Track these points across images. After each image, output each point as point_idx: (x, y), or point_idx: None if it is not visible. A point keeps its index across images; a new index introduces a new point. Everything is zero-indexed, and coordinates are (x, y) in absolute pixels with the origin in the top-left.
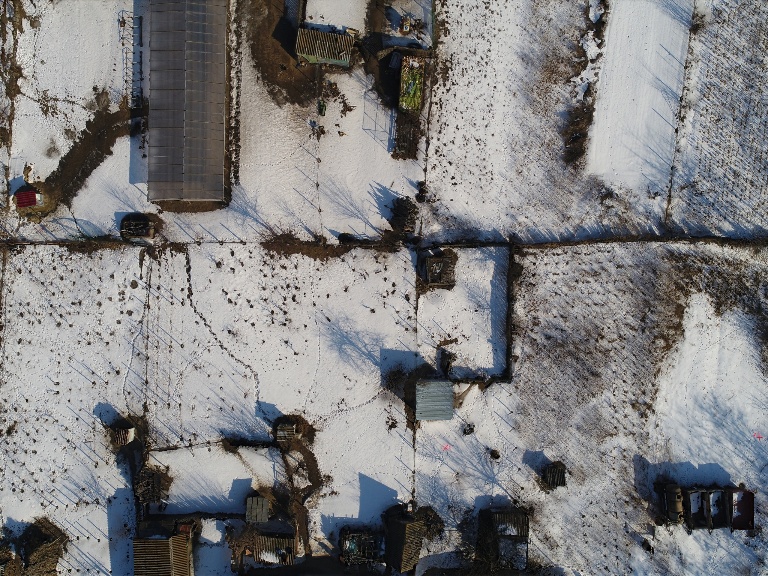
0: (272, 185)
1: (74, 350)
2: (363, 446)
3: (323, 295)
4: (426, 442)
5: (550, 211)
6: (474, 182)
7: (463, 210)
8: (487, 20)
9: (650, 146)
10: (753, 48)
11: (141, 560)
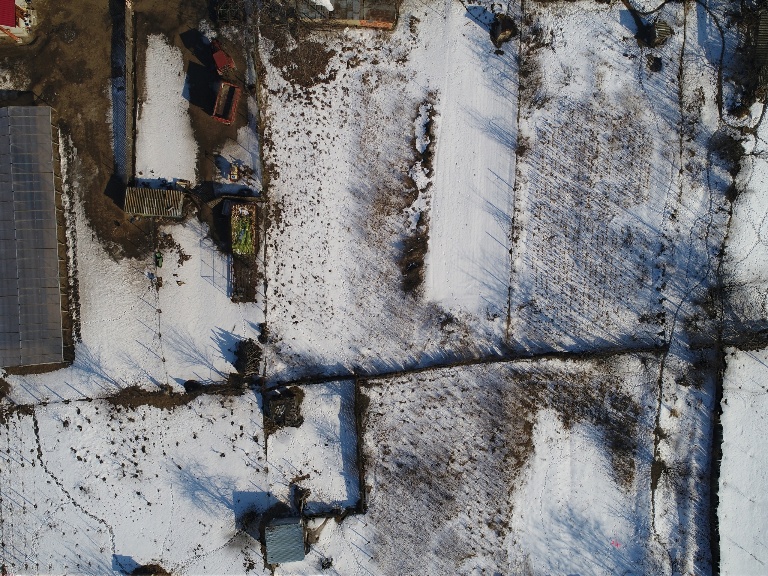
0: (114, 340)
1: None
2: None
3: (172, 444)
4: None
5: (392, 341)
6: (315, 319)
7: (306, 347)
8: (316, 160)
9: (486, 268)
10: (579, 165)
11: None
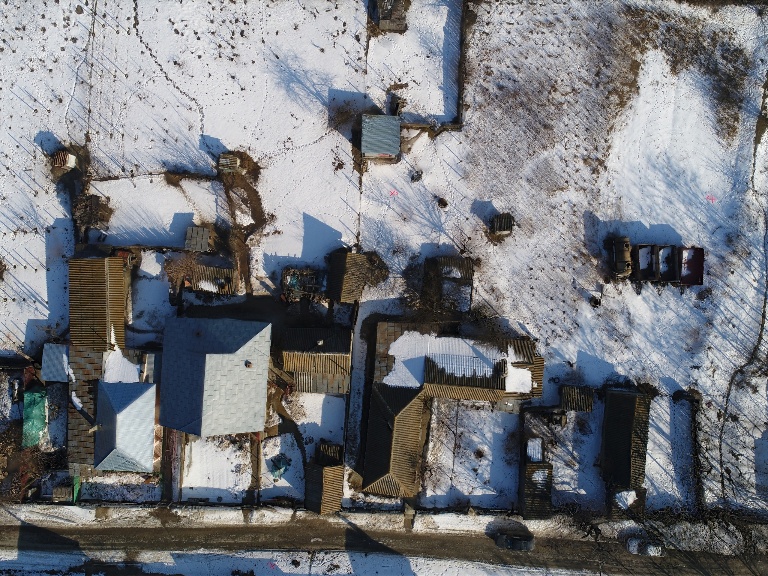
0: None
1: (16, 76)
2: (308, 186)
3: (272, 32)
4: (373, 186)
5: None
6: None
7: None
8: None
9: None
10: None
11: (76, 280)
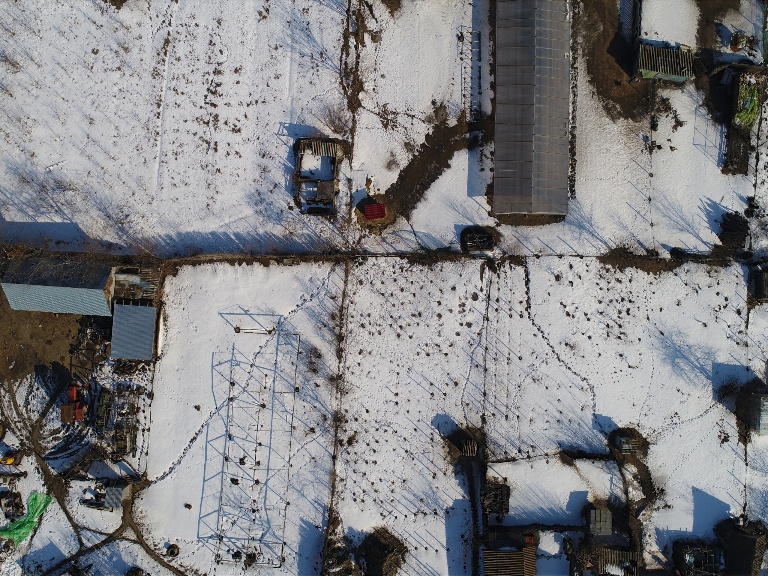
0: (607, 199)
1: (413, 361)
2: (696, 460)
3: (656, 309)
4: (756, 456)
5: None
6: None
7: None
8: None
9: None
10: None
11: (492, 571)
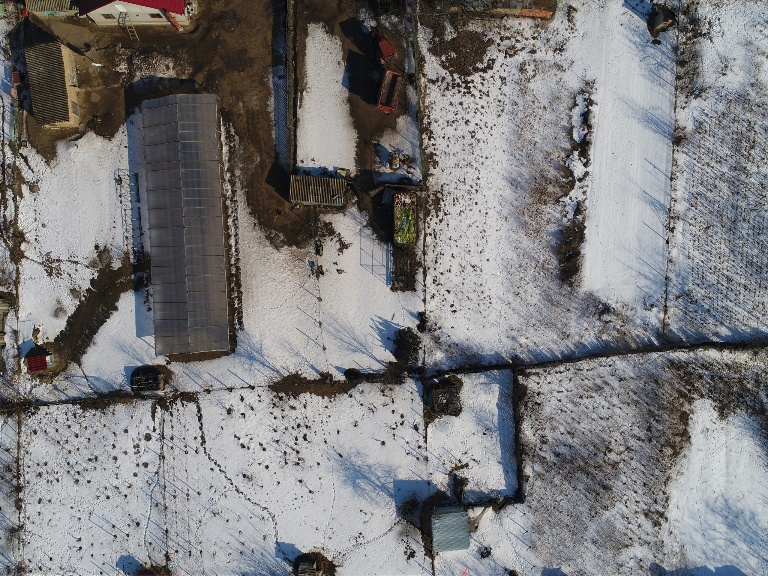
0: (276, 328)
1: (93, 505)
2: None
3: (333, 432)
4: (445, 568)
5: (549, 330)
6: (473, 308)
7: (464, 336)
8: (474, 149)
9: (642, 258)
10: (736, 155)
11: None
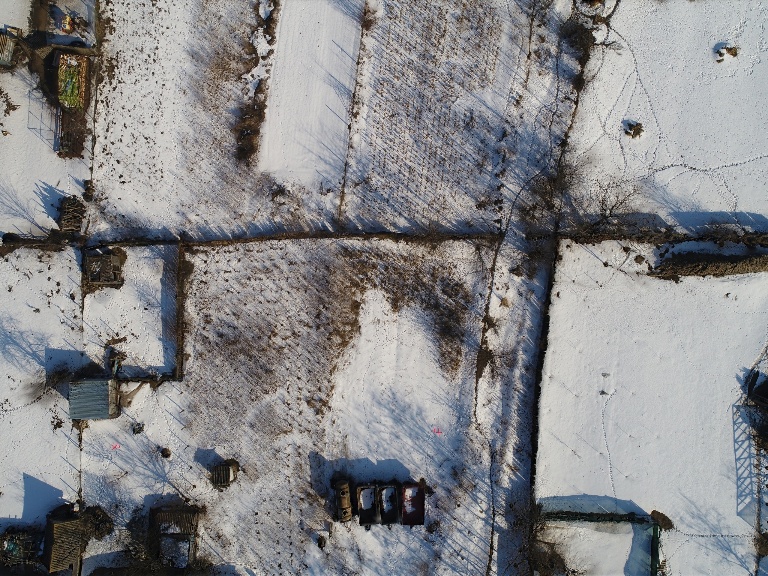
0: None
1: None
2: (28, 446)
3: None
4: (94, 441)
5: (222, 209)
6: (143, 180)
7: (132, 208)
8: (154, 18)
9: (324, 142)
10: (425, 43)
11: None
